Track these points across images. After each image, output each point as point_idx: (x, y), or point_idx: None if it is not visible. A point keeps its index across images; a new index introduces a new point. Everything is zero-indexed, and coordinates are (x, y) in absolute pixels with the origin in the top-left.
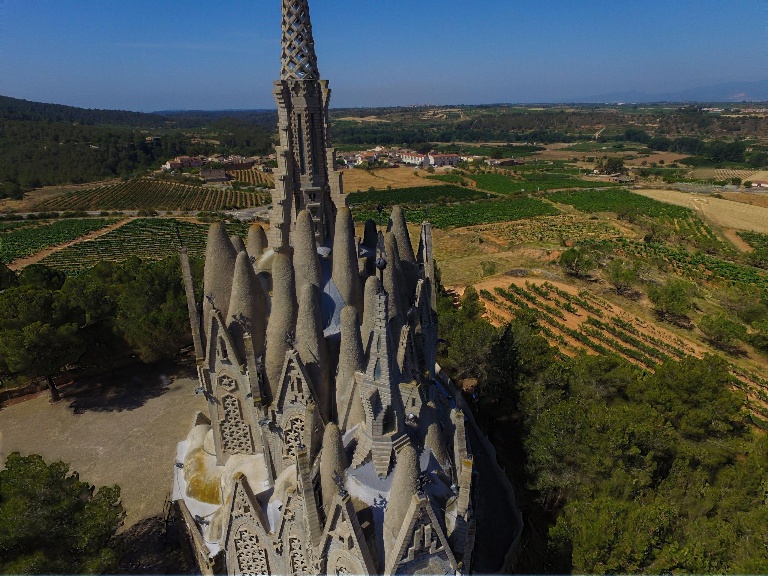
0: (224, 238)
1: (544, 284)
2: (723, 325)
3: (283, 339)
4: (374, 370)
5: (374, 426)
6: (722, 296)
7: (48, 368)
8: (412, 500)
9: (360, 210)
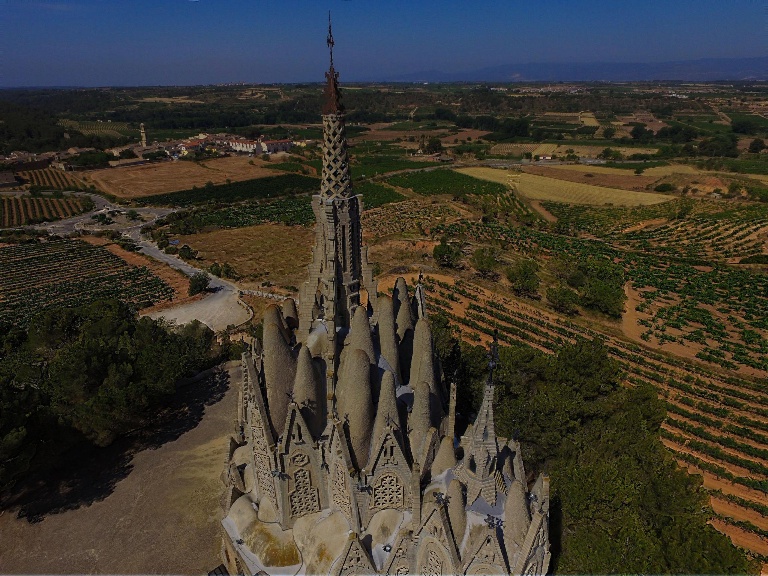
0: (282, 336)
1: (426, 278)
2: (563, 294)
3: (364, 416)
4: (483, 435)
5: (484, 472)
6: (553, 267)
7: None
8: (535, 516)
9: (206, 211)
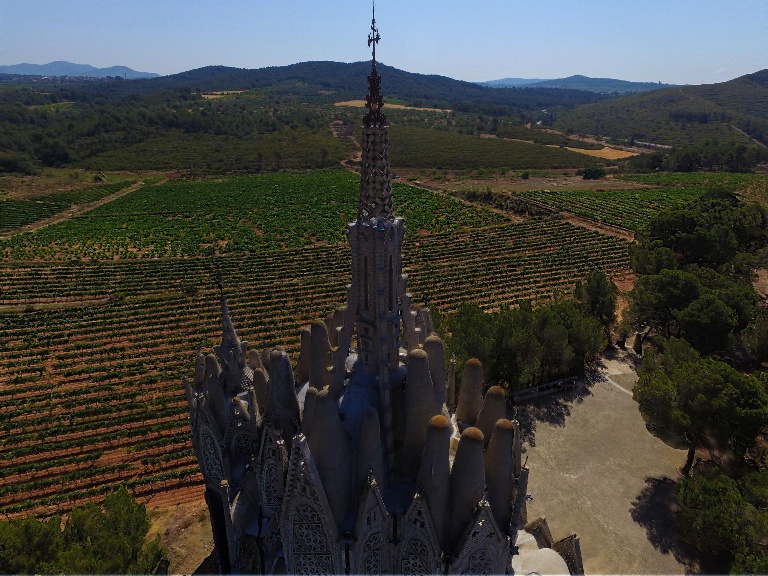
0: None
1: None
2: None
3: None
4: None
5: None
6: None
7: (658, 427)
8: None
9: None
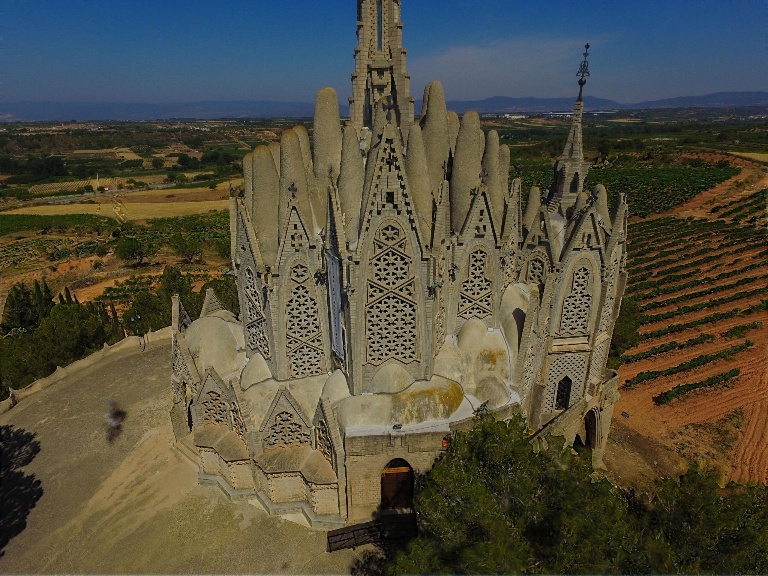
0: None
1: (130, 278)
2: None
3: None
4: None
5: None
6: None
7: None
8: (622, 197)
9: None
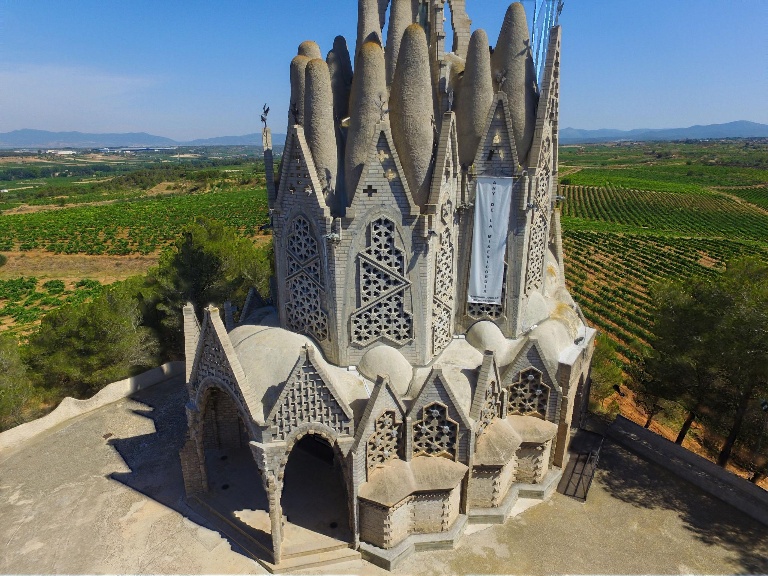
0: None
1: None
2: None
3: None
4: None
5: None
6: None
7: None
8: None
9: None
